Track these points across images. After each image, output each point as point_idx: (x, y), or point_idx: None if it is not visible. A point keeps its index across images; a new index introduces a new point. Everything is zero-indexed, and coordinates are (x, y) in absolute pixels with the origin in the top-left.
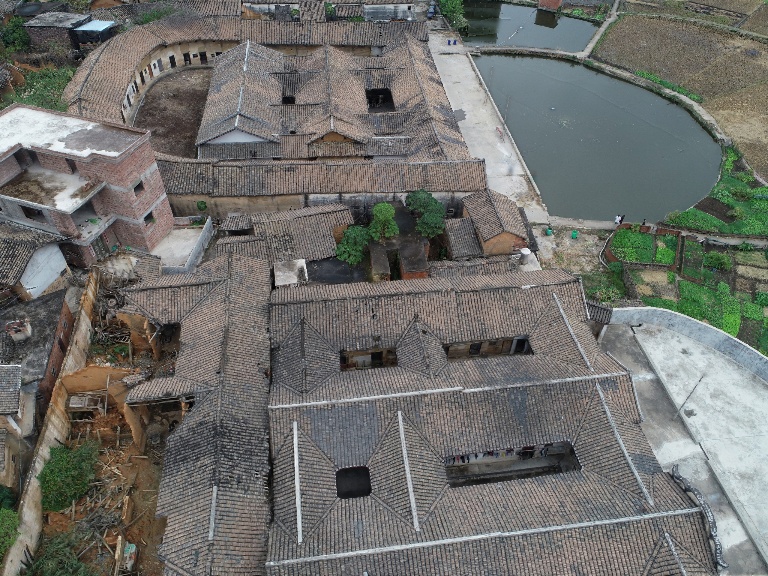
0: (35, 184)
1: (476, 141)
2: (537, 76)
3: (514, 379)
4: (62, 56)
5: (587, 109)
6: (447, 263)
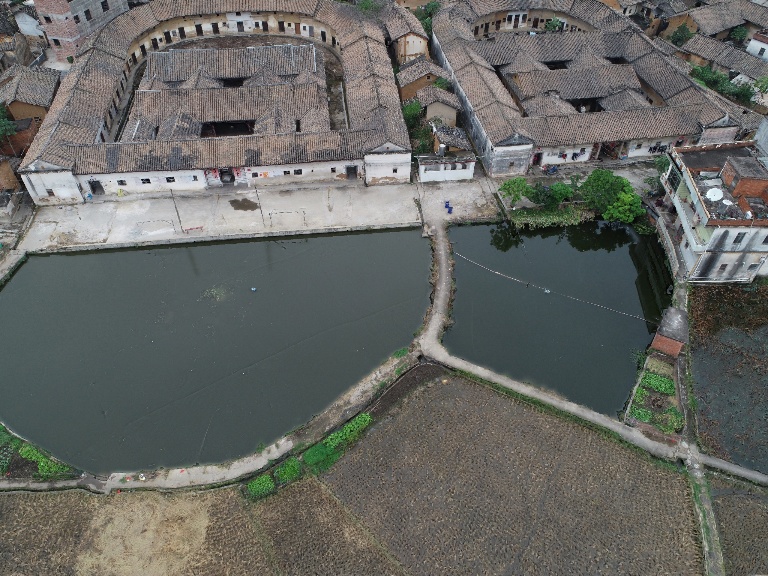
0: None
1: (184, 214)
2: (374, 296)
3: None
4: None
5: (247, 325)
6: None
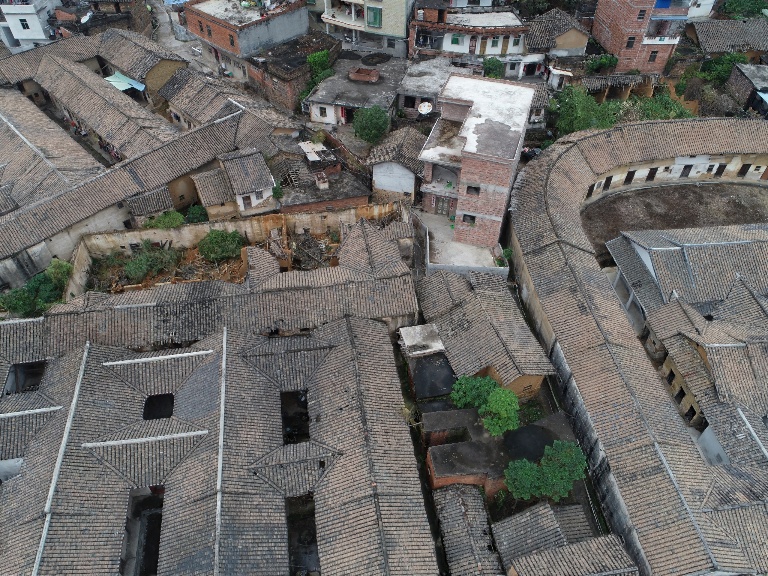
0: (455, 133)
1: None
2: None
3: (234, 560)
4: (719, 105)
5: None
6: (476, 514)
